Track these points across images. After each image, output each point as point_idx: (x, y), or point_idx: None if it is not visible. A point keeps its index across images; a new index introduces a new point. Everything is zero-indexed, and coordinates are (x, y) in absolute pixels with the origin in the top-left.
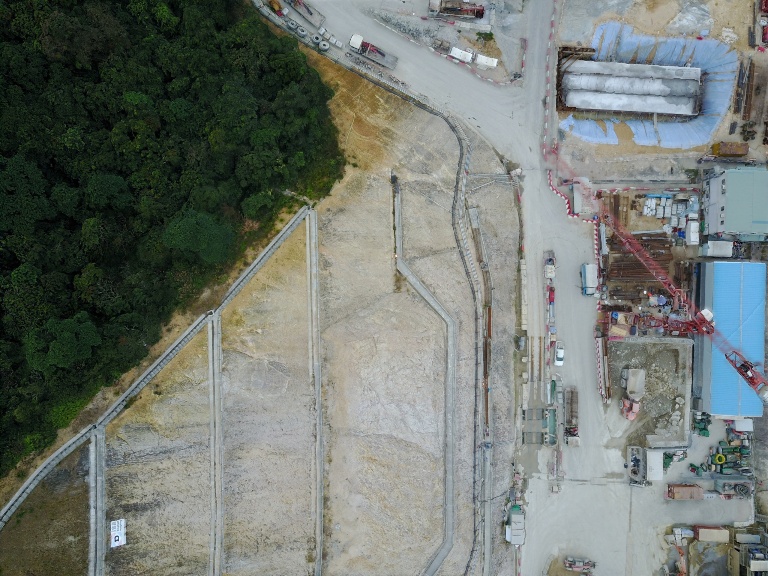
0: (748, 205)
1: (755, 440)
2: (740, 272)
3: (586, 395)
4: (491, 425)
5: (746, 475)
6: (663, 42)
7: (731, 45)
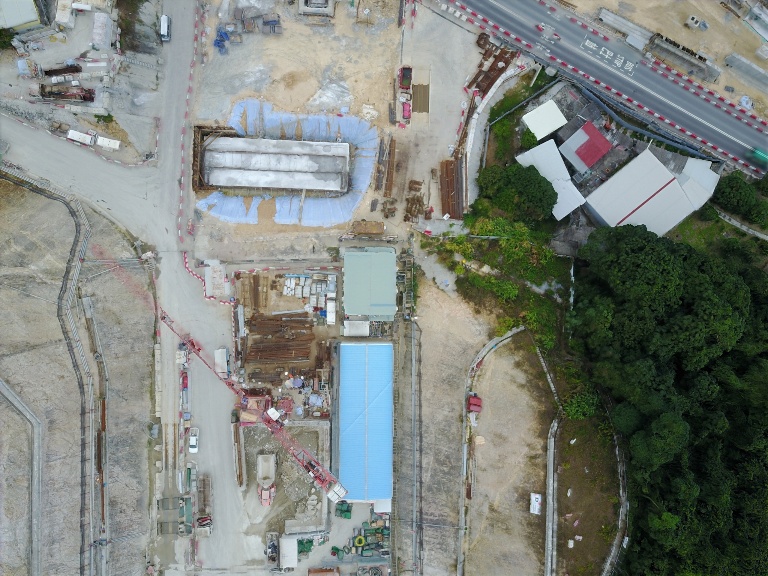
0: (366, 288)
1: (397, 520)
2: (365, 354)
3: (224, 481)
4: (106, 522)
5: (384, 557)
6: (305, 119)
7: (372, 122)
